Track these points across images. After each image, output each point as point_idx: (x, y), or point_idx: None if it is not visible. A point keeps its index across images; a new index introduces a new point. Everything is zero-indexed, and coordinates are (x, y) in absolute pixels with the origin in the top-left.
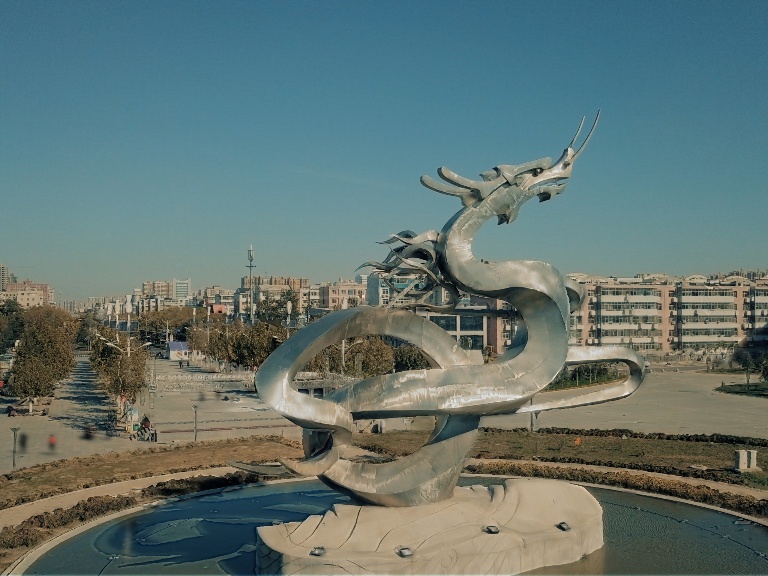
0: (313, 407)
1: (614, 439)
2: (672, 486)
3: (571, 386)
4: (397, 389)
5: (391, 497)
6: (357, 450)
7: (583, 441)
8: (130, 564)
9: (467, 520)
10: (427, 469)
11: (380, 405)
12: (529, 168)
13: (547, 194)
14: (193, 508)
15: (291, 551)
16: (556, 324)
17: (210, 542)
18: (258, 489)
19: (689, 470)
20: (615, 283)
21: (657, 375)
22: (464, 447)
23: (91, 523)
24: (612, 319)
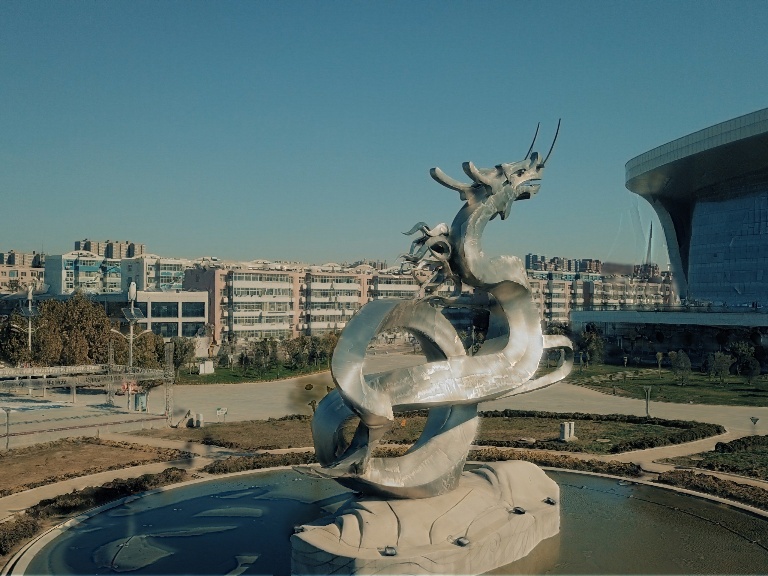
0: (384, 403)
1: (424, 419)
2: (546, 458)
3: (315, 371)
4: (427, 381)
5: (418, 489)
6: (202, 446)
7: (400, 423)
8: None
9: (490, 504)
10: (444, 458)
11: (415, 398)
12: (518, 168)
13: (527, 194)
14: (115, 525)
15: (361, 554)
16: (531, 315)
17: (187, 559)
18: (159, 497)
19: (531, 443)
20: (318, 271)
21: (375, 358)
22: (470, 434)
23: (26, 556)
24: (320, 305)
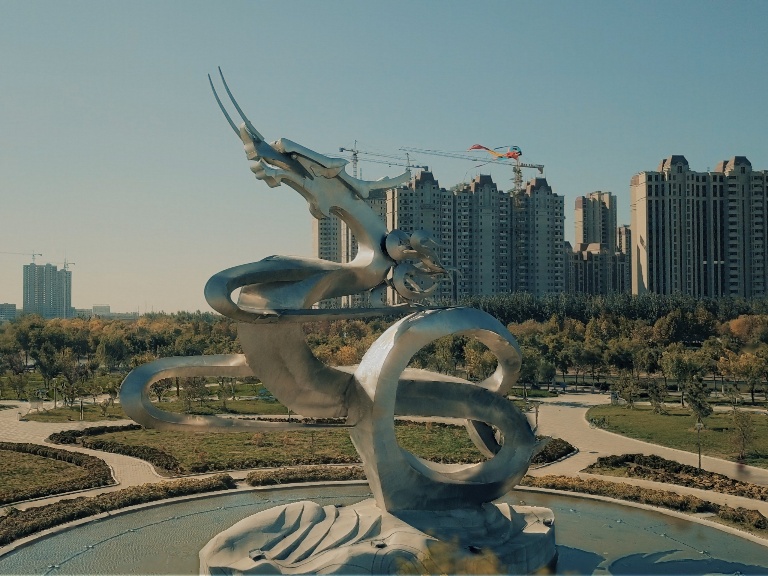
0: None
1: None
2: None
3: None
4: None
5: None
6: None
7: None
8: (677, 550)
9: None
10: None
11: None
12: None
13: None
14: None
15: None
16: None
17: None
18: None
19: None
20: None
21: None
22: None
23: None
24: None
